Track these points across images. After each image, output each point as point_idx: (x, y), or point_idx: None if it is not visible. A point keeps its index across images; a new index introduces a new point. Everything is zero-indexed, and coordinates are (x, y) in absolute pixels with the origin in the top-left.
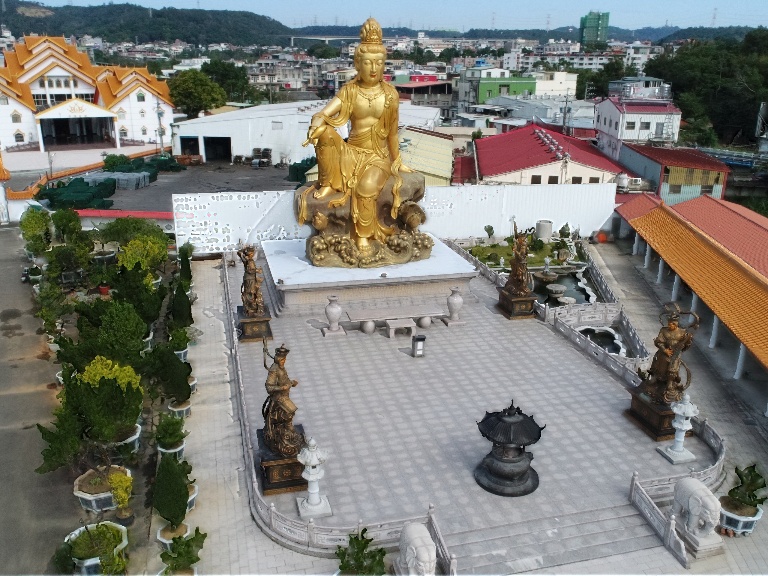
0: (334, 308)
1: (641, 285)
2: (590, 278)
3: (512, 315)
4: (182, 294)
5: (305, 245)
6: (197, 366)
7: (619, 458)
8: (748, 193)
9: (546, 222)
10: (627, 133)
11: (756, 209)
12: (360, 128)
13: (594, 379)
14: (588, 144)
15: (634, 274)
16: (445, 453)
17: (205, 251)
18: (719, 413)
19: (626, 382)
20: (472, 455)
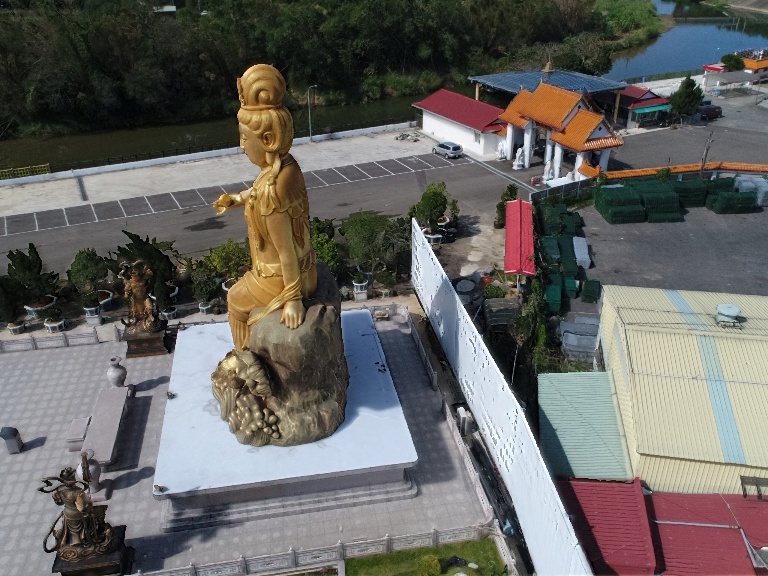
0: None
1: None
2: None
3: None
4: None
5: None
6: (102, 329)
7: None
8: None
9: None
10: None
11: None
12: None
13: None
14: None
15: None
16: None
17: None
18: None
19: None
20: None
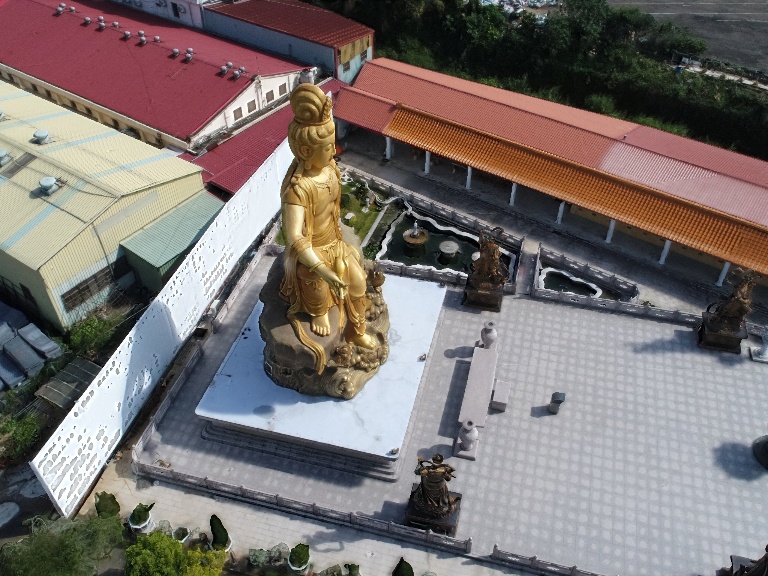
0: (475, 432)
1: (465, 199)
2: (423, 213)
3: (500, 307)
4: (407, 566)
5: (257, 378)
6: None
7: (760, 384)
8: None
9: None
10: None
11: None
12: (321, 224)
13: (638, 329)
14: None
15: (437, 187)
16: (738, 473)
17: (91, 481)
18: (709, 303)
19: (651, 317)
20: (744, 459)
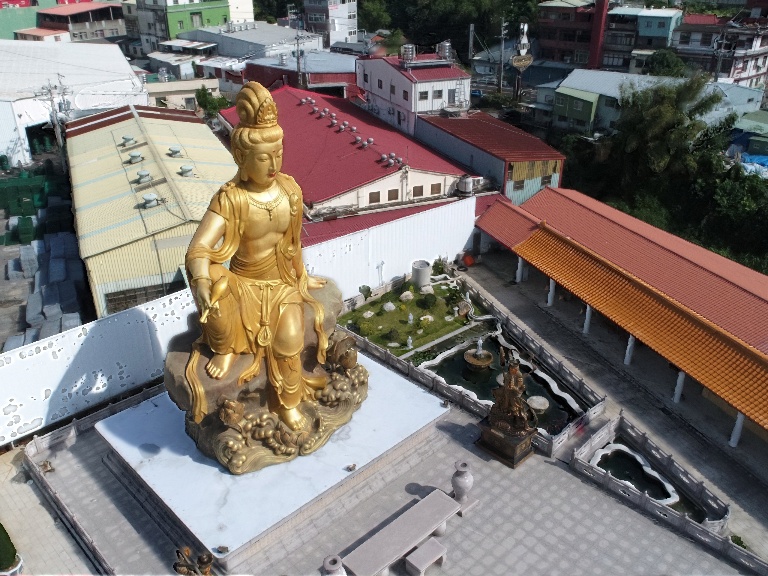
0: None
1: (573, 341)
2: (513, 341)
3: (515, 462)
4: None
5: (175, 417)
6: None
7: None
8: None
9: (421, 263)
10: (421, 104)
11: None
12: (257, 252)
13: (699, 568)
14: (348, 102)
15: (549, 321)
16: None
17: None
18: None
19: (731, 560)
20: None
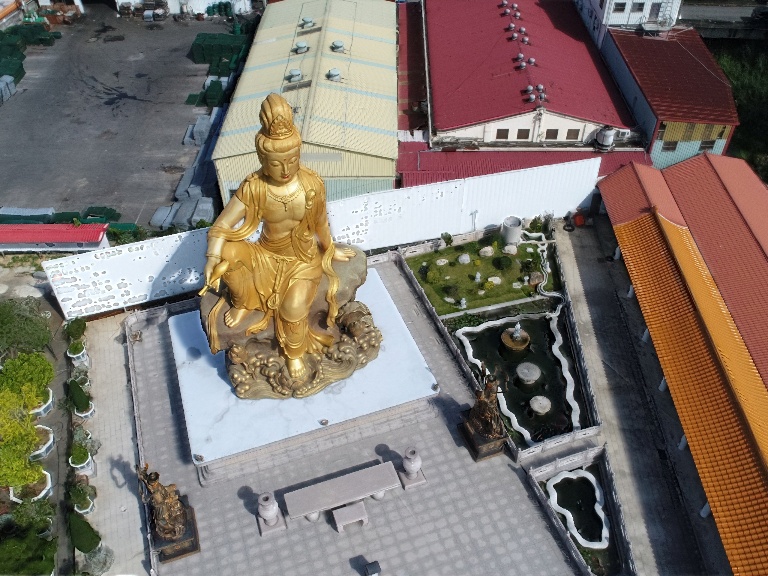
0: (268, 511)
1: (624, 346)
2: (566, 327)
3: (478, 457)
4: (77, 526)
5: None
6: None
7: None
8: (744, 35)
9: (515, 220)
10: (614, 17)
11: (751, 70)
12: (275, 232)
13: None
14: None
15: (616, 315)
16: None
17: (101, 310)
18: None
19: None
20: None
